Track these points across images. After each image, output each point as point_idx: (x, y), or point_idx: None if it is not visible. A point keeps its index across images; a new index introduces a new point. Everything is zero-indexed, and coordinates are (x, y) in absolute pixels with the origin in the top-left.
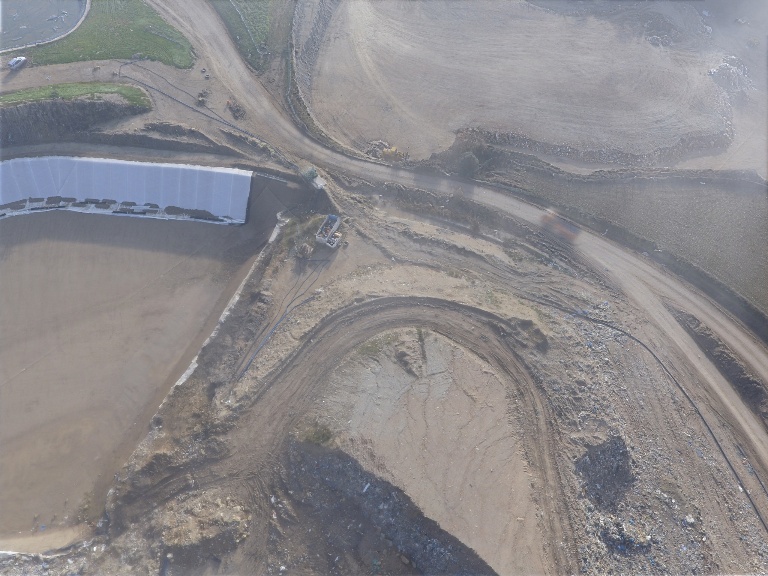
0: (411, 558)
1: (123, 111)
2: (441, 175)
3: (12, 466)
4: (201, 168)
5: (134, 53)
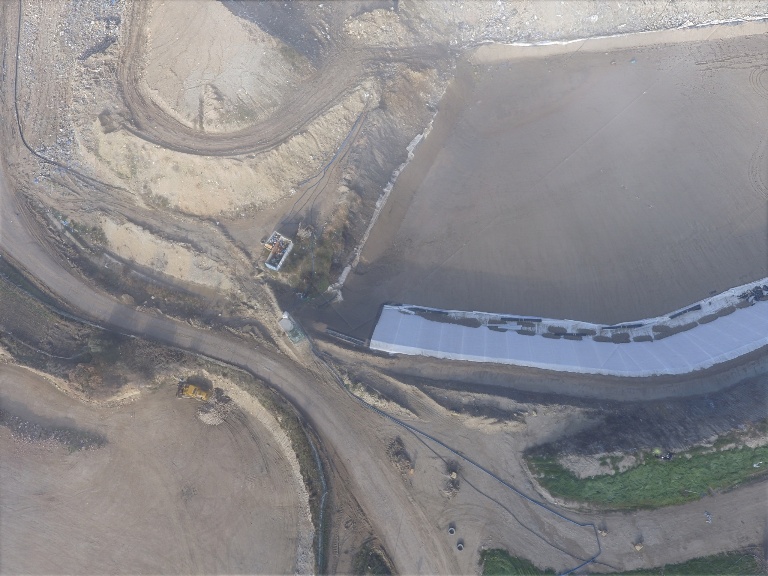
0: (240, 5)
1: (563, 446)
2: None
3: (542, 96)
4: (435, 353)
5: None
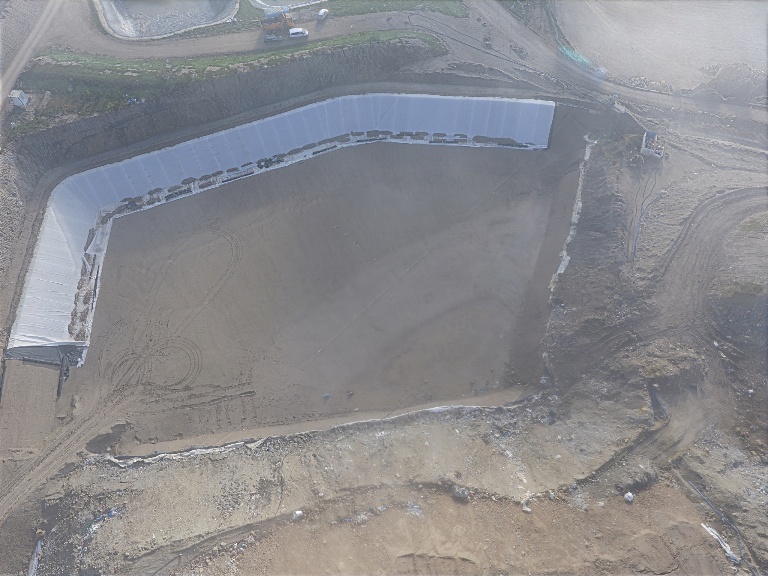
0: None
1: (427, 53)
2: (720, 100)
3: (433, 345)
4: (509, 100)
5: (415, 5)
